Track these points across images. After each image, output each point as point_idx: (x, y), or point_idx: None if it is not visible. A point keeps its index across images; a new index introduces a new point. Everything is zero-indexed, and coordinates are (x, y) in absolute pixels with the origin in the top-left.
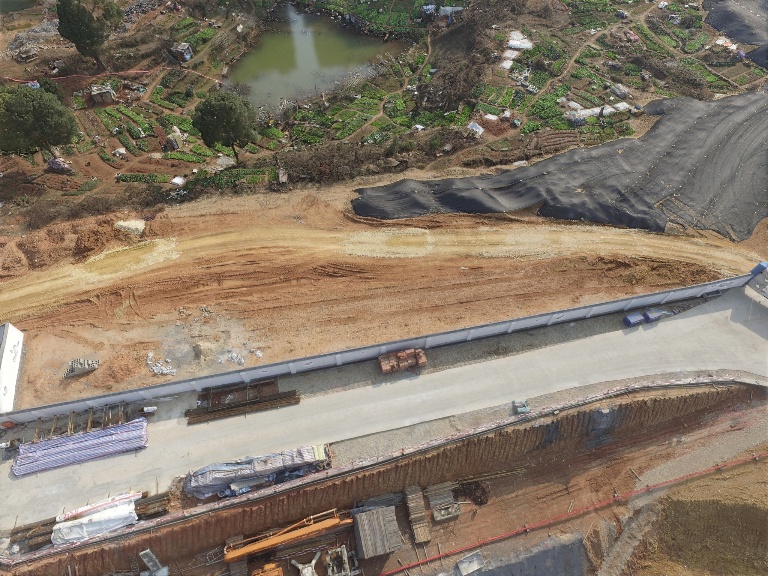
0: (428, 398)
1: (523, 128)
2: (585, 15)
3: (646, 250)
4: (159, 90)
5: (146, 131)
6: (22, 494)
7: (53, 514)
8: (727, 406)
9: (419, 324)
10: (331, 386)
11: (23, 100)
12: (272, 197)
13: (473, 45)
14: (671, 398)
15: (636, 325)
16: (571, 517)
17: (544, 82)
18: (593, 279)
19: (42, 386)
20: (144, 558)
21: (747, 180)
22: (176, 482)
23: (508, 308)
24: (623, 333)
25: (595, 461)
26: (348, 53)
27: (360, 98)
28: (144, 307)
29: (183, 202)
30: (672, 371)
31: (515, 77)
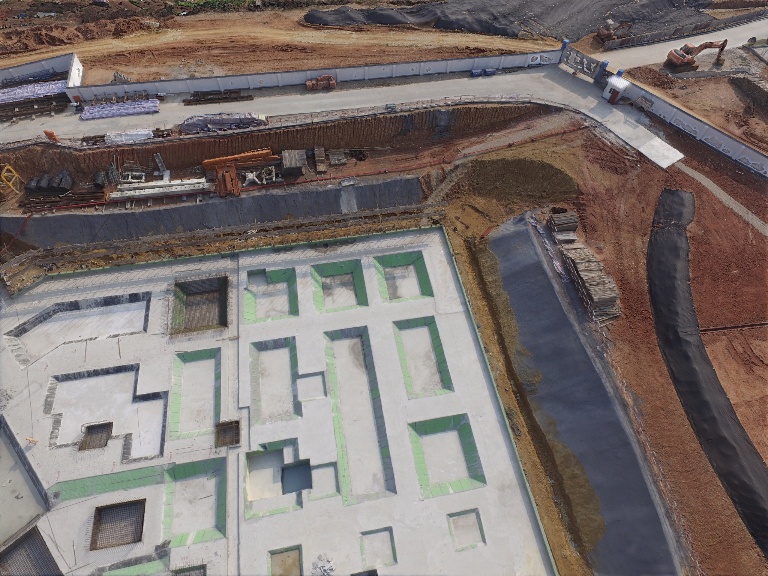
0: (334, 101)
1: None
2: None
3: (502, 46)
4: None
5: None
6: (87, 126)
7: None
8: (525, 118)
9: None
10: (274, 94)
11: None
12: (249, 13)
13: None
14: (487, 108)
15: (478, 76)
16: (415, 168)
17: None
18: (459, 57)
19: None
20: (156, 159)
21: (590, 13)
22: (176, 126)
23: None
24: (468, 79)
25: (437, 145)
26: None
27: None
28: (159, 59)
29: (187, 15)
30: (492, 96)
31: None
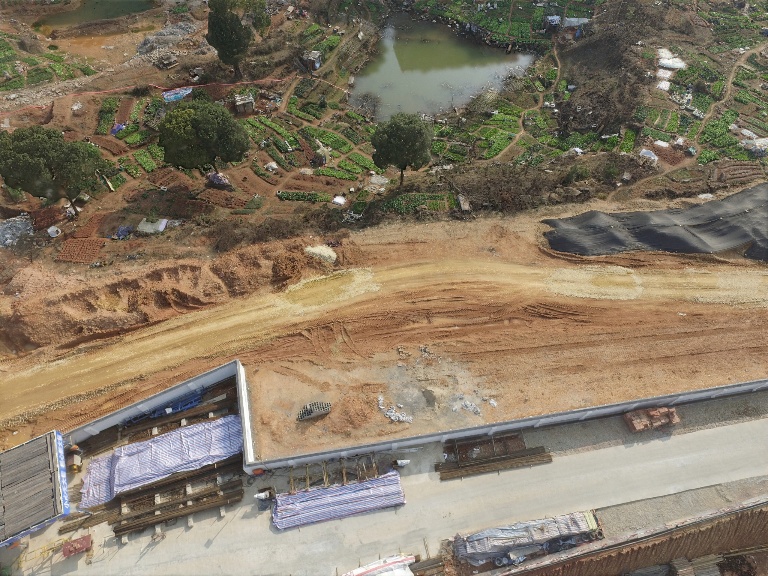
0: (687, 463)
1: (700, 157)
2: (728, 32)
3: None
4: (294, 100)
5: (292, 144)
6: (289, 550)
7: (327, 575)
8: None
9: (654, 377)
10: (580, 444)
11: (209, 117)
12: (457, 226)
13: (618, 62)
14: None
15: None
16: None
17: (708, 106)
18: None
19: (279, 429)
20: None
21: None
22: (445, 545)
23: (744, 363)
24: None
25: None
26: (472, 64)
27: (497, 114)
28: (359, 344)
29: (365, 227)
30: None
31: (677, 100)
